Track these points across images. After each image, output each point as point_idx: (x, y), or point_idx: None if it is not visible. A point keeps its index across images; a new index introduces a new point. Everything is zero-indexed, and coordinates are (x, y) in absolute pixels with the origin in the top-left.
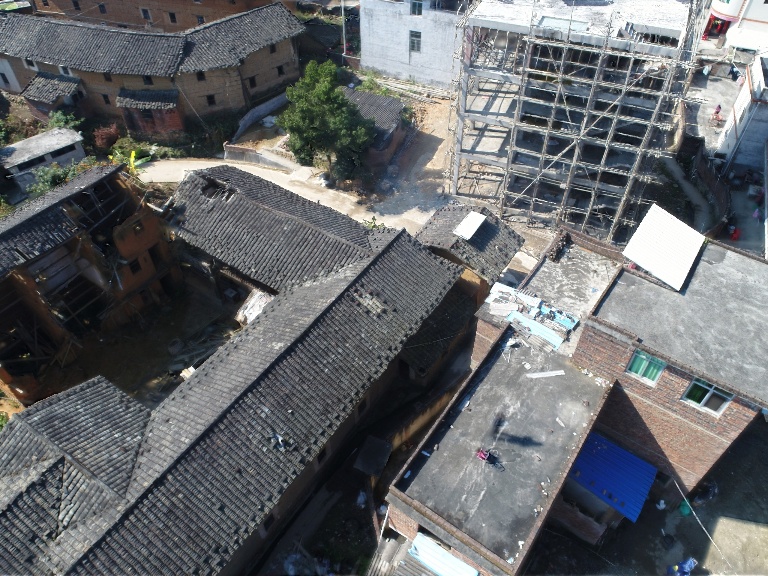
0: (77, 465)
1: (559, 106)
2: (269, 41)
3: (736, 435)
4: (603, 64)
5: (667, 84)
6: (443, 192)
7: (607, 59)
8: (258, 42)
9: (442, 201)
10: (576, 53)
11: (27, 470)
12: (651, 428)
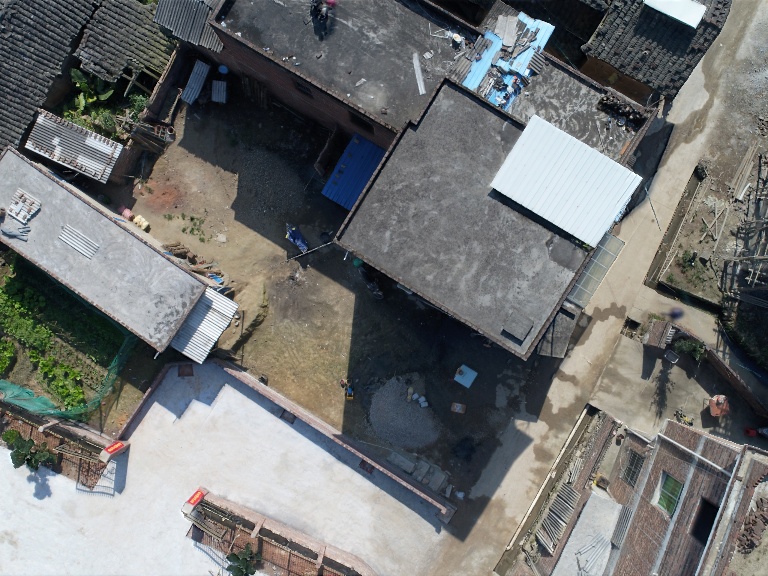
0: None
1: None
2: None
3: None
4: None
5: None
6: None
7: None
8: None
9: None
10: None
11: None
12: None
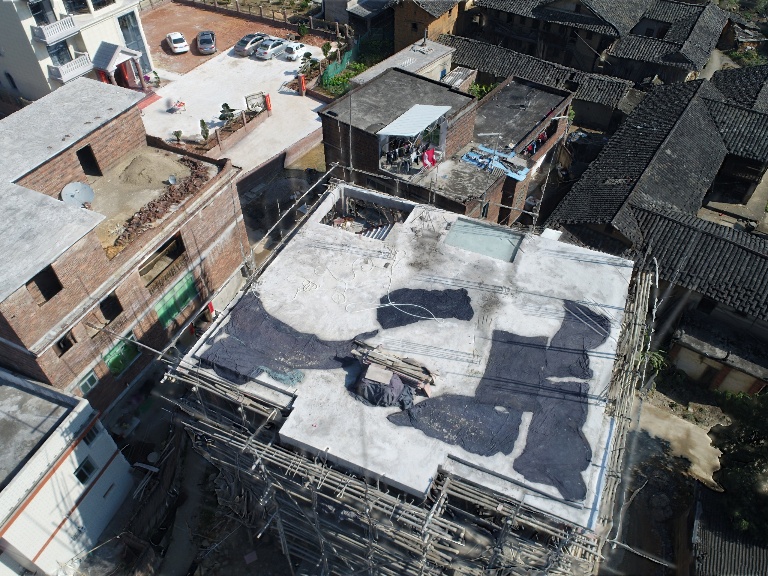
0: (739, 106)
1: None
2: None
3: None
4: None
5: None
6: None
7: None
8: None
9: None
10: None
11: (766, 112)
12: None
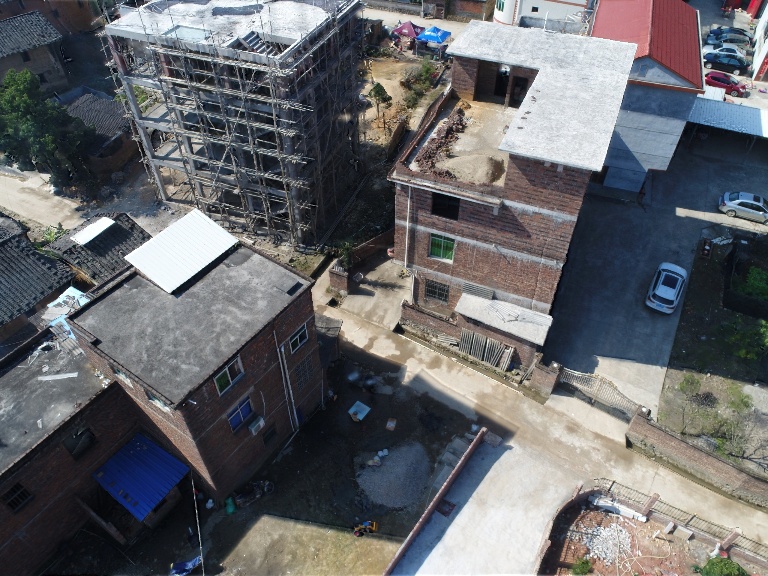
0: None
1: (202, 113)
2: (16, 50)
3: (190, 434)
4: (223, 72)
5: (272, 91)
6: (157, 198)
7: (227, 67)
8: (3, 51)
9: (155, 207)
10: (200, 61)
11: None
12: (160, 428)
